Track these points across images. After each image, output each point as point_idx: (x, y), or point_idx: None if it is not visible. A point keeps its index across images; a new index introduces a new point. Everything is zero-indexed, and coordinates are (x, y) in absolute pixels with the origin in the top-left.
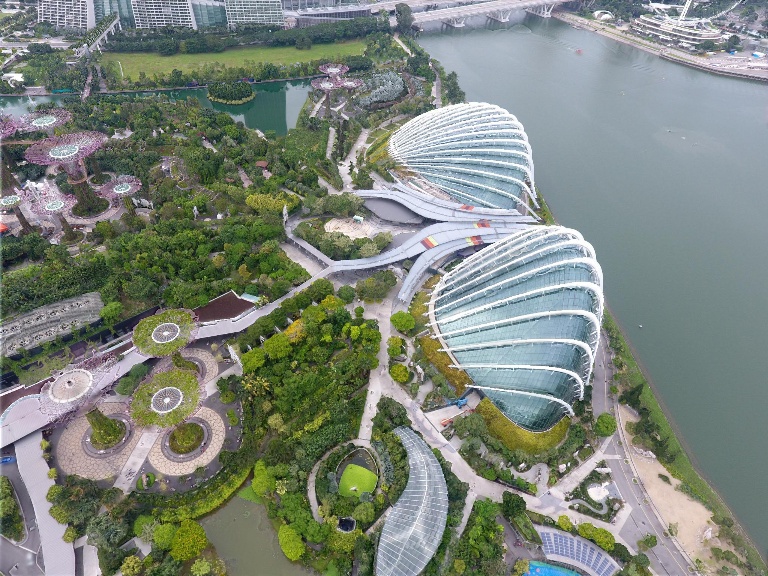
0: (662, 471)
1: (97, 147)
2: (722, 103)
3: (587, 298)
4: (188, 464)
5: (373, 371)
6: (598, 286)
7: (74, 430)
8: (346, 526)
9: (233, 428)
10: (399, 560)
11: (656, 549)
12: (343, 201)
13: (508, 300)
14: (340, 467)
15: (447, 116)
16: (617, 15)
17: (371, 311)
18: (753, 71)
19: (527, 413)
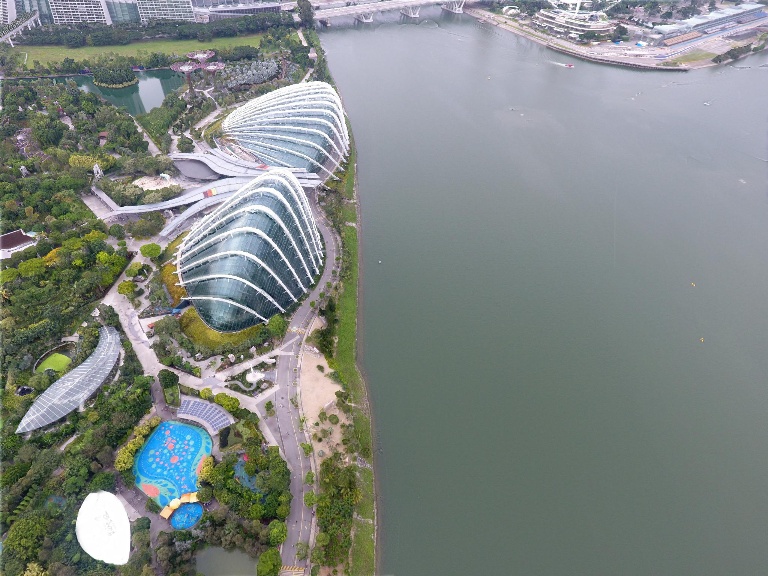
0: (323, 363)
1: None
2: (580, 86)
3: (264, 220)
4: None
5: (113, 289)
6: (269, 209)
7: None
8: (25, 393)
9: None
10: (44, 411)
11: (281, 415)
12: (151, 161)
13: (215, 226)
14: (46, 355)
15: None
16: (522, 10)
17: (136, 246)
18: (626, 58)
19: (215, 316)
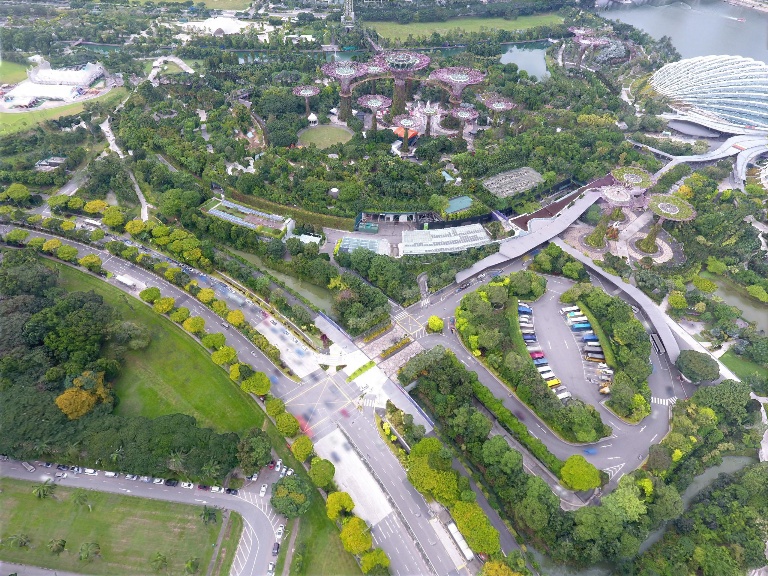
0: None
1: None
2: None
3: None
4: (658, 259)
5: (745, 219)
6: None
7: (570, 239)
8: None
9: (672, 243)
10: None
11: None
12: (656, 120)
13: None
14: None
15: (699, 65)
16: None
17: (718, 187)
18: None
19: None
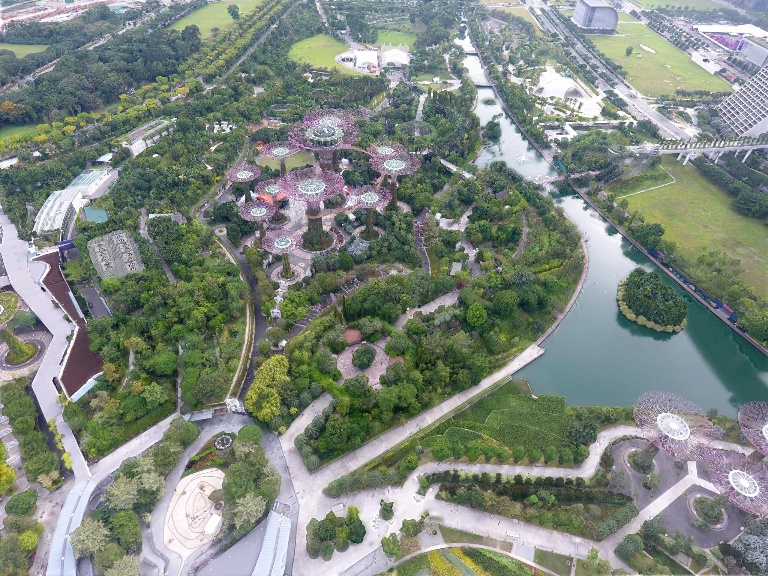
0: None
1: (312, 201)
2: None
3: None
4: None
5: None
6: None
7: None
8: None
9: None
10: None
11: None
12: (236, 486)
13: None
14: None
15: None
16: None
17: None
18: None
19: None
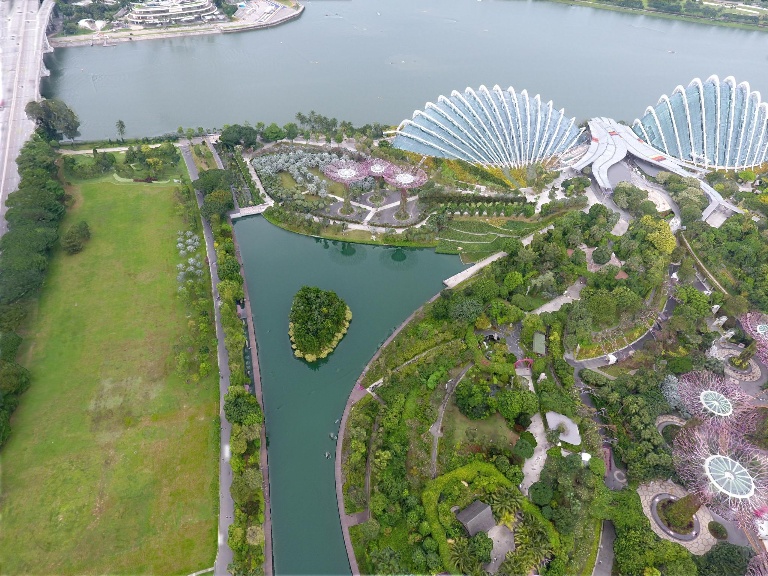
0: None
1: None
2: (335, 38)
3: None
4: None
5: None
6: None
7: None
8: None
9: None
10: None
11: None
12: (637, 189)
13: None
14: None
15: None
16: None
17: None
18: (278, 14)
19: None
